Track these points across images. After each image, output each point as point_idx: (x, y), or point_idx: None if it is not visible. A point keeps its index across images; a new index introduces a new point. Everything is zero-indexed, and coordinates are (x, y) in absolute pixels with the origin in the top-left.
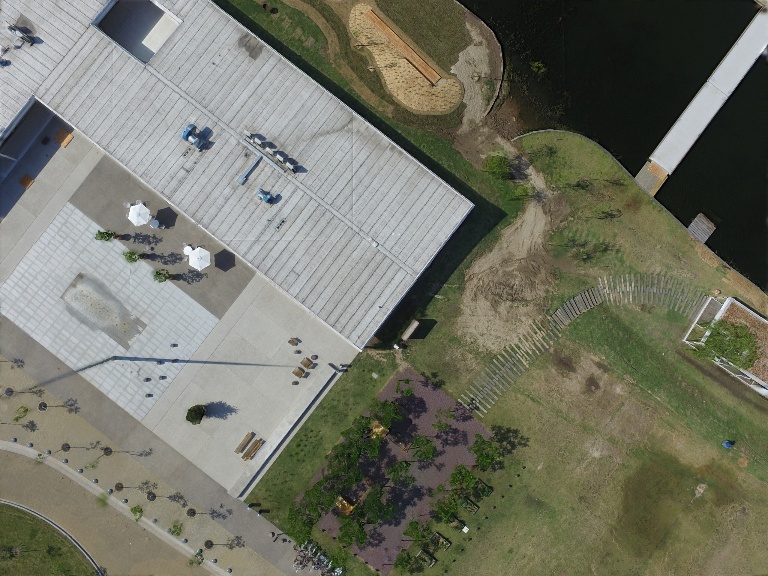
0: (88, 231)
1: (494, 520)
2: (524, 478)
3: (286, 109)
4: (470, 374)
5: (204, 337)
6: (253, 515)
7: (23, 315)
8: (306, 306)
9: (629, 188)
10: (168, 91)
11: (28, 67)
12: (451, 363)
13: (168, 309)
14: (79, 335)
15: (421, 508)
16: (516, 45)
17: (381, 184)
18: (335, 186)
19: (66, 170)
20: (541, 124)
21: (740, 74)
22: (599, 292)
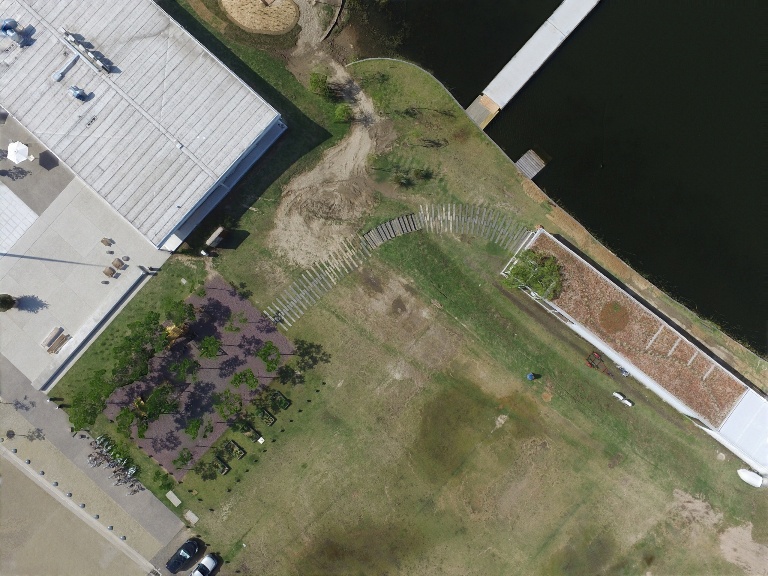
0: None
1: (290, 433)
2: (323, 394)
3: (106, 12)
4: (278, 287)
5: (23, 232)
6: (55, 409)
7: None
8: (108, 201)
9: (458, 119)
10: None
11: None
12: (260, 275)
13: None
14: None
15: (219, 415)
16: None
17: (191, 89)
18: (146, 88)
19: None
20: (378, 53)
21: (581, 15)
22: (419, 219)
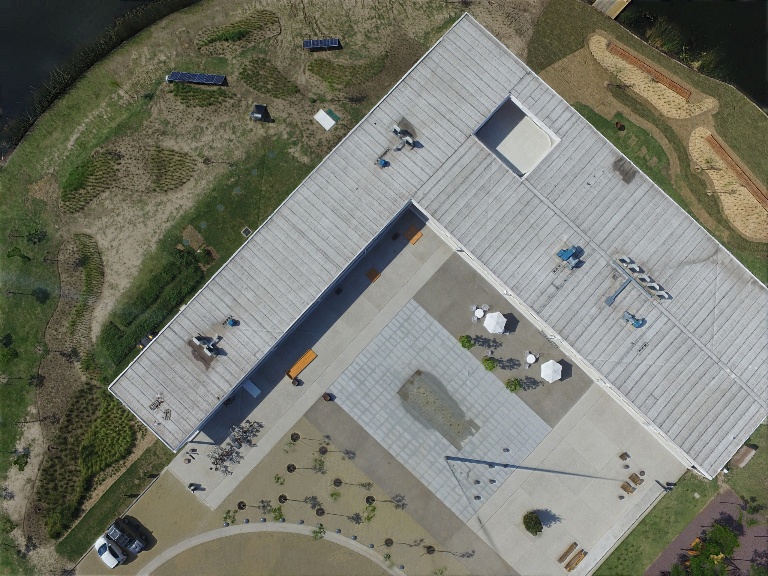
0: (430, 329)
1: None
2: None
3: (656, 235)
4: None
5: (536, 444)
6: None
7: (358, 407)
8: (663, 431)
9: None
10: (543, 207)
11: (407, 170)
12: None
13: (502, 413)
14: (413, 432)
15: None
16: None
17: (741, 317)
18: (698, 315)
19: (413, 267)
20: None
21: None
22: None
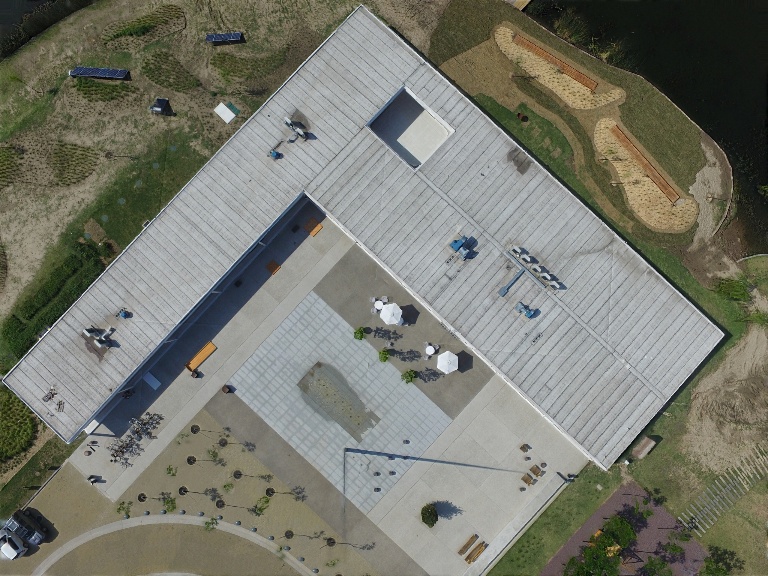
0: (330, 321)
1: None
2: None
3: (550, 226)
4: (692, 493)
5: (436, 436)
6: None
7: (258, 399)
8: (557, 422)
9: None
10: (436, 198)
11: (300, 162)
12: (674, 481)
13: (403, 405)
14: (312, 424)
15: None
16: (745, 168)
17: (637, 307)
18: (593, 305)
19: (313, 259)
20: (764, 247)
21: None
22: None
